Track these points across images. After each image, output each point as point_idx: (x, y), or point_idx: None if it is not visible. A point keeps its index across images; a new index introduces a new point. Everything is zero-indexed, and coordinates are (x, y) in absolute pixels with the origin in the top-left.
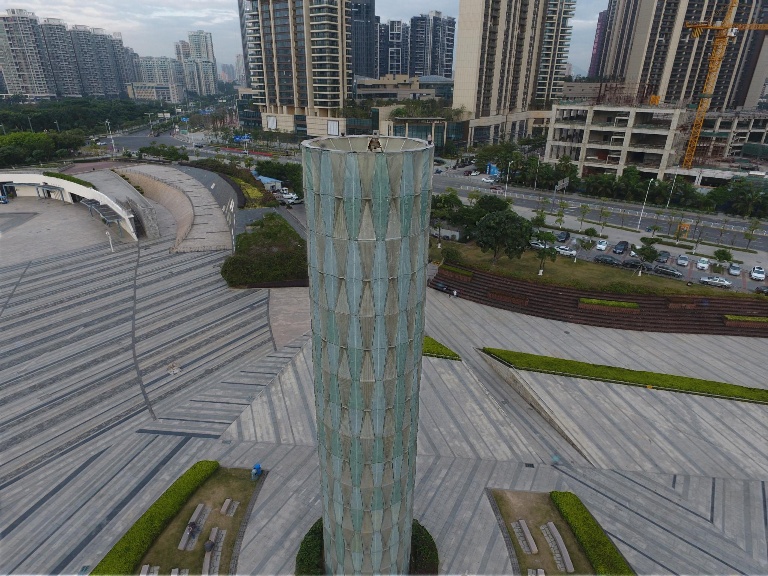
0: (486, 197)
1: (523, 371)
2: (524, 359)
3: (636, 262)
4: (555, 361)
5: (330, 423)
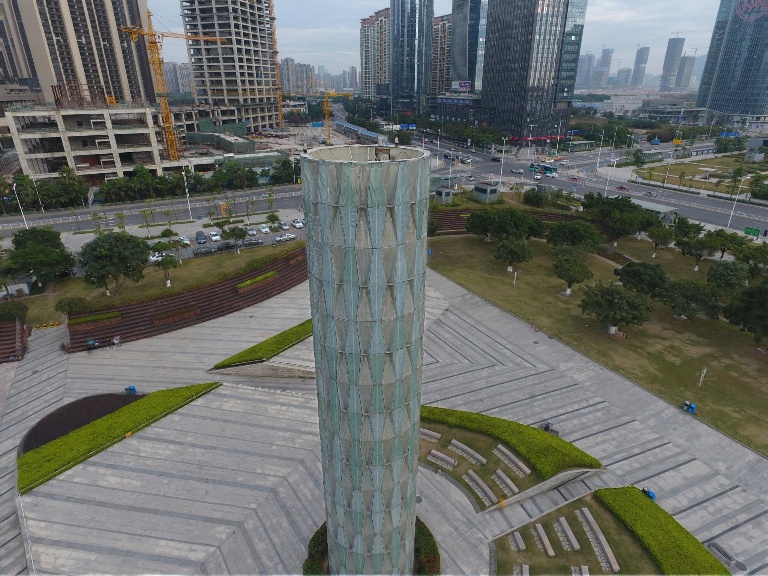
0: (25, 232)
1: (273, 358)
2: (261, 350)
3: (227, 244)
4: (278, 338)
5: (391, 433)
